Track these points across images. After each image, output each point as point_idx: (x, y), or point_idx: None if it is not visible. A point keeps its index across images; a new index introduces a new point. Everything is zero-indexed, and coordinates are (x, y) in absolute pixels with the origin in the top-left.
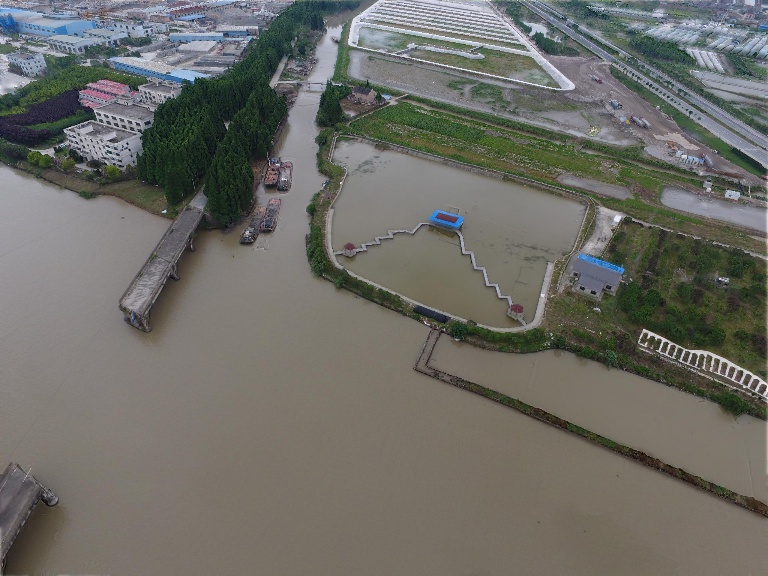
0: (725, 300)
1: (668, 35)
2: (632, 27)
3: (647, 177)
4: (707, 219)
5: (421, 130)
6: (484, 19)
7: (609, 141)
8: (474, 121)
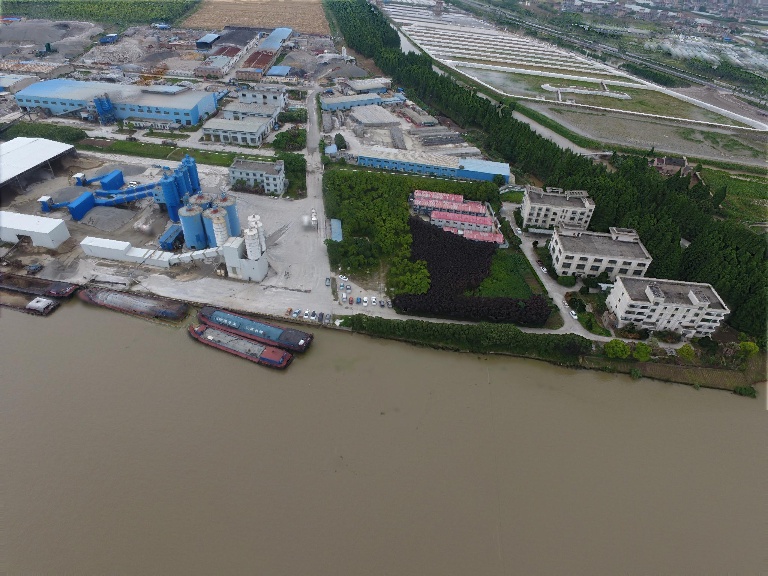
0: None
1: (686, 53)
2: None
3: None
4: None
5: None
6: (529, 46)
7: None
8: None
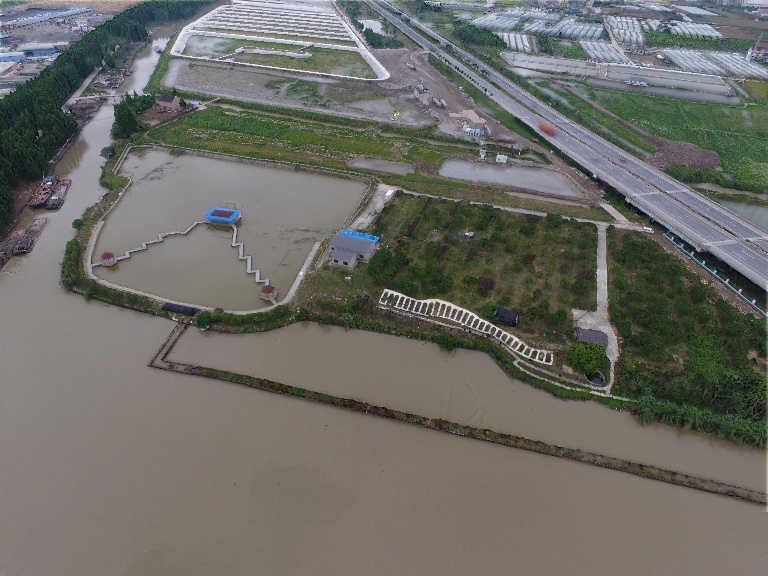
0: (465, 251)
1: (491, 23)
2: (461, 17)
3: (432, 152)
4: (474, 183)
5: (223, 132)
6: (323, 19)
7: (408, 123)
8: (281, 117)
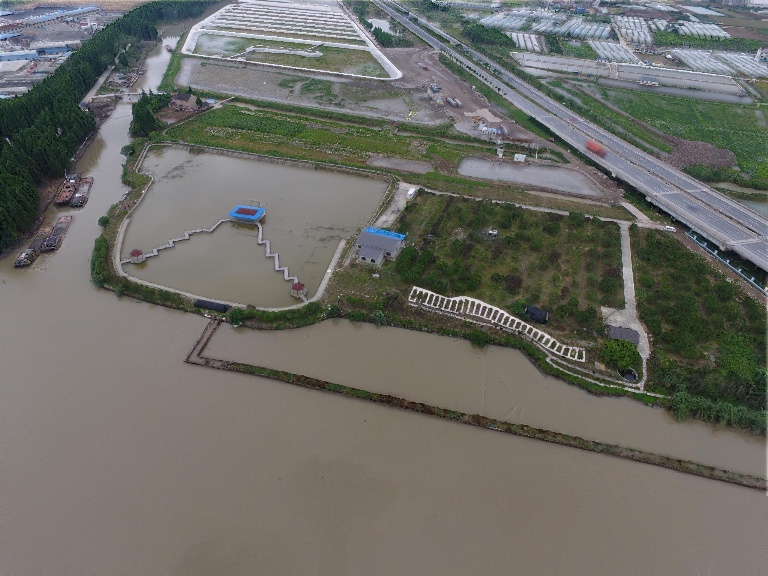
0: (490, 250)
1: (499, 22)
2: (469, 17)
3: (450, 151)
4: (494, 181)
5: (241, 130)
6: (330, 18)
7: (424, 122)
8: (297, 116)
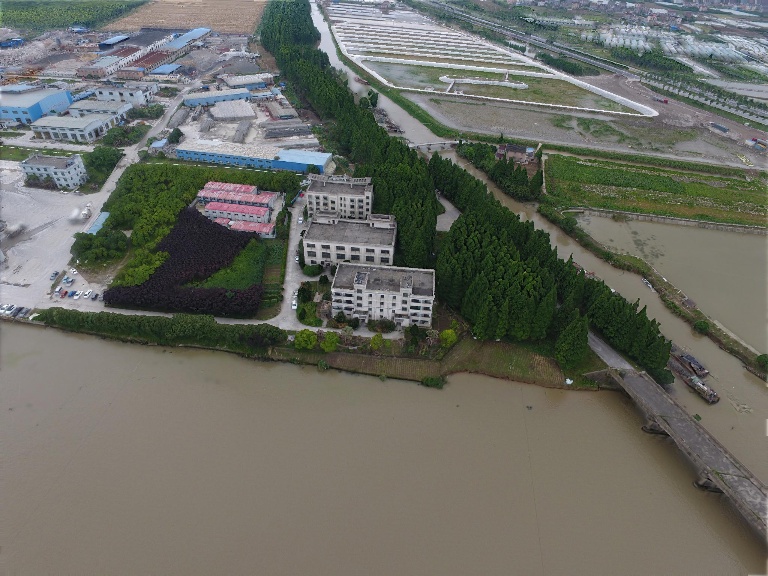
0: None
1: None
2: (584, 37)
3: None
4: None
5: (622, 188)
6: (456, 40)
7: None
8: (646, 167)
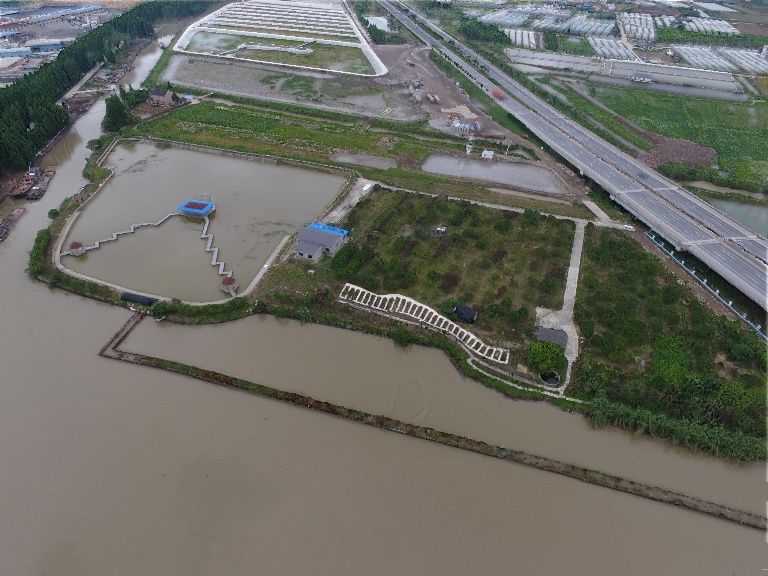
0: (434, 247)
1: (500, 19)
2: (470, 14)
3: (418, 147)
4: (455, 178)
5: (212, 125)
6: (330, 16)
7: (398, 118)
8: (271, 112)
